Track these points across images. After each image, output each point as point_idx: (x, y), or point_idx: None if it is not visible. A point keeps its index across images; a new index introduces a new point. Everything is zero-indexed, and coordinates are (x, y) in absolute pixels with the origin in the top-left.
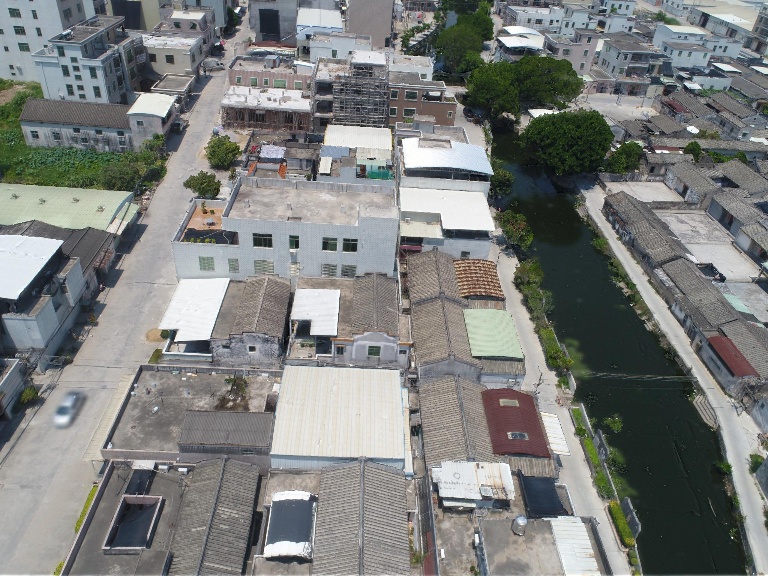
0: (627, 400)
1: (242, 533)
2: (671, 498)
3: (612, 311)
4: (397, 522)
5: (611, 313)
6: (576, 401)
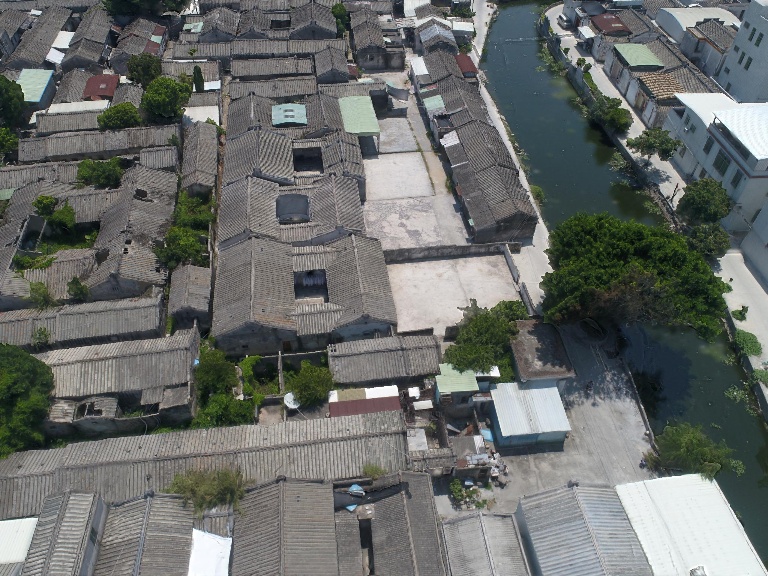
0: (530, 78)
1: (705, 1)
2: (517, 46)
3: (533, 126)
4: (650, 3)
5: (534, 125)
6: (564, 76)
